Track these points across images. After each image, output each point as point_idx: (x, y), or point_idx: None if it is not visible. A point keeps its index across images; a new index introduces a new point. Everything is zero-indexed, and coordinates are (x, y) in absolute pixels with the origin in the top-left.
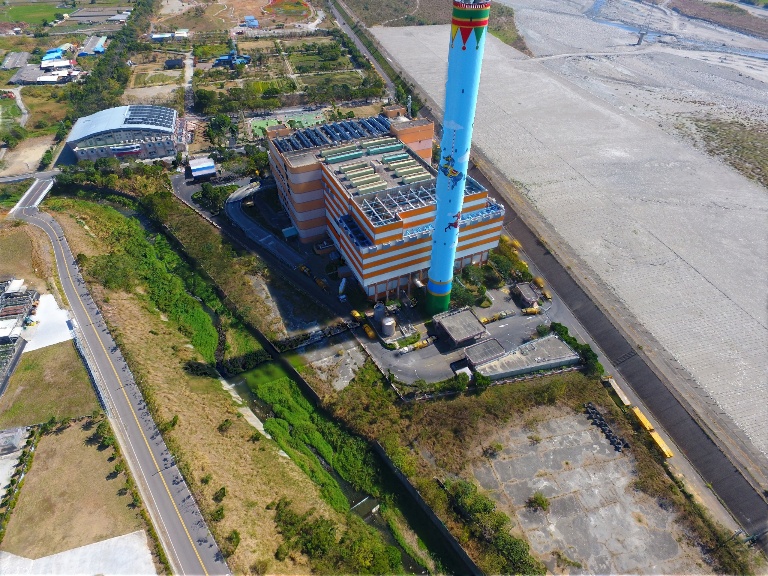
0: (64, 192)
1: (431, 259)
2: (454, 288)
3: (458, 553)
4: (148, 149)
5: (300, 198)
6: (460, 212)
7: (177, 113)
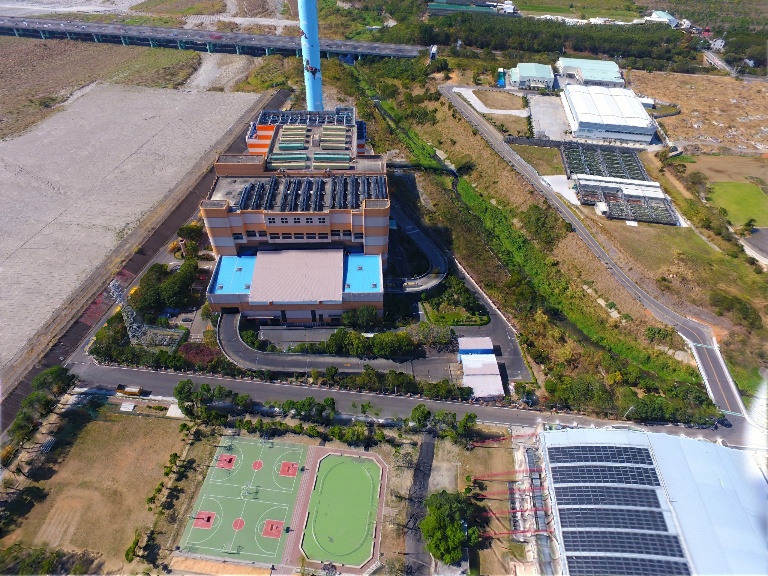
0: None
1: None
2: None
3: None
4: None
5: None
6: None
7: None
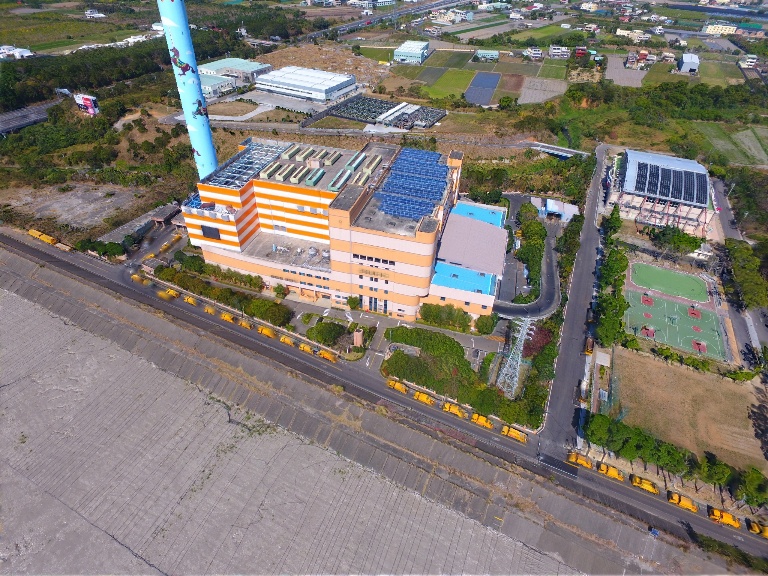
0: None
1: None
2: None
3: None
4: None
5: None
6: None
7: None
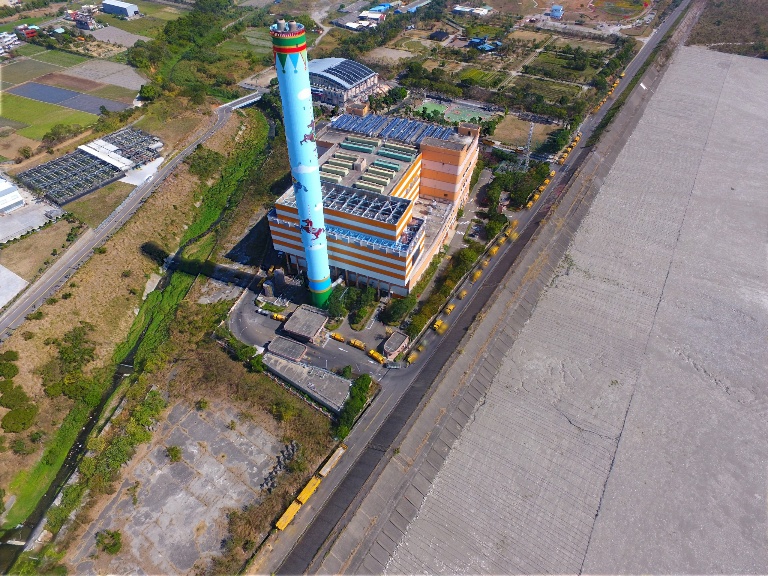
0: (263, 106)
1: None
2: (333, 294)
3: None
4: (327, 96)
5: None
6: (311, 220)
7: (375, 75)
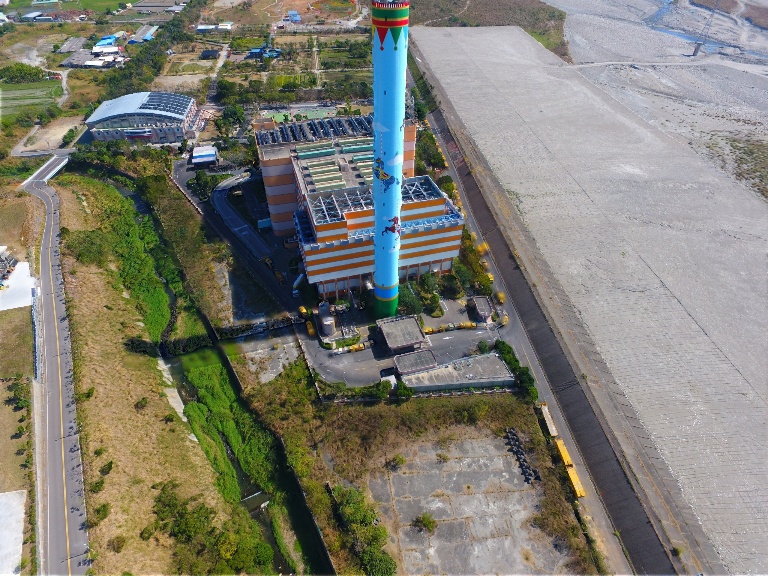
0: (77, 169)
1: (375, 262)
2: (403, 294)
3: (329, 561)
4: (159, 134)
5: (271, 191)
6: (397, 217)
7: (194, 101)
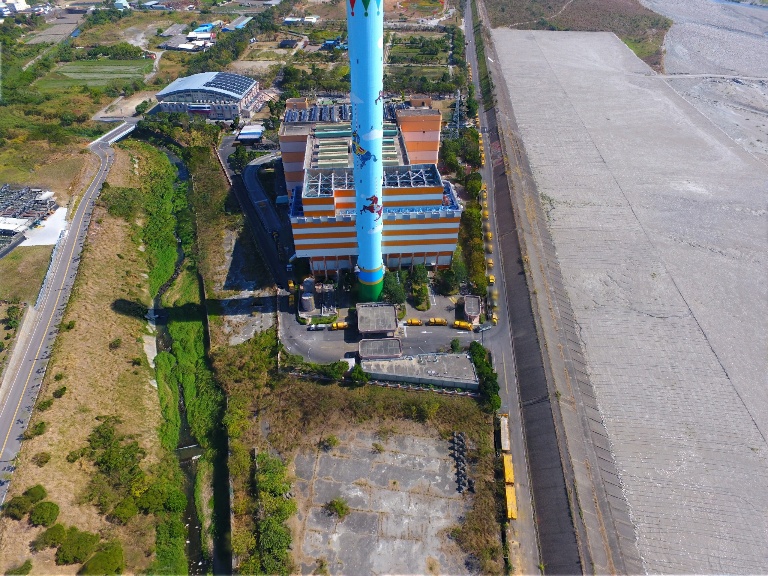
0: (141, 136)
1: None
2: (388, 281)
3: None
4: (217, 111)
5: (287, 167)
6: (376, 196)
7: (257, 84)
